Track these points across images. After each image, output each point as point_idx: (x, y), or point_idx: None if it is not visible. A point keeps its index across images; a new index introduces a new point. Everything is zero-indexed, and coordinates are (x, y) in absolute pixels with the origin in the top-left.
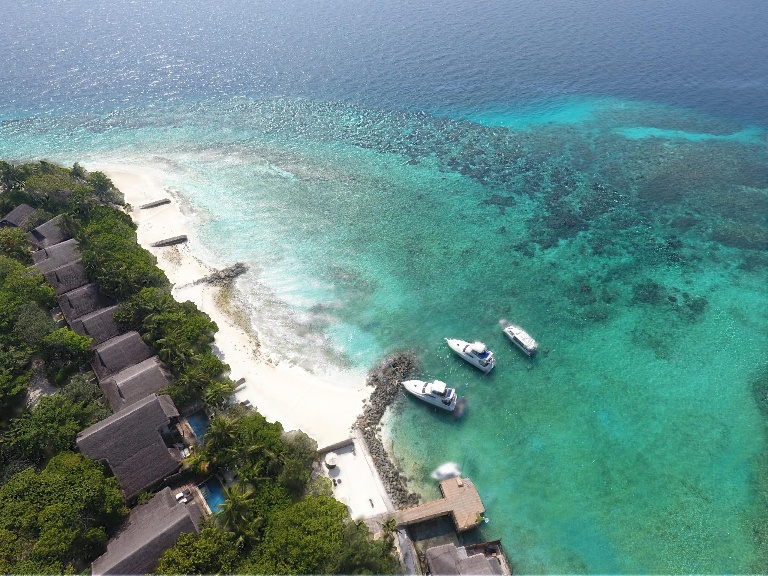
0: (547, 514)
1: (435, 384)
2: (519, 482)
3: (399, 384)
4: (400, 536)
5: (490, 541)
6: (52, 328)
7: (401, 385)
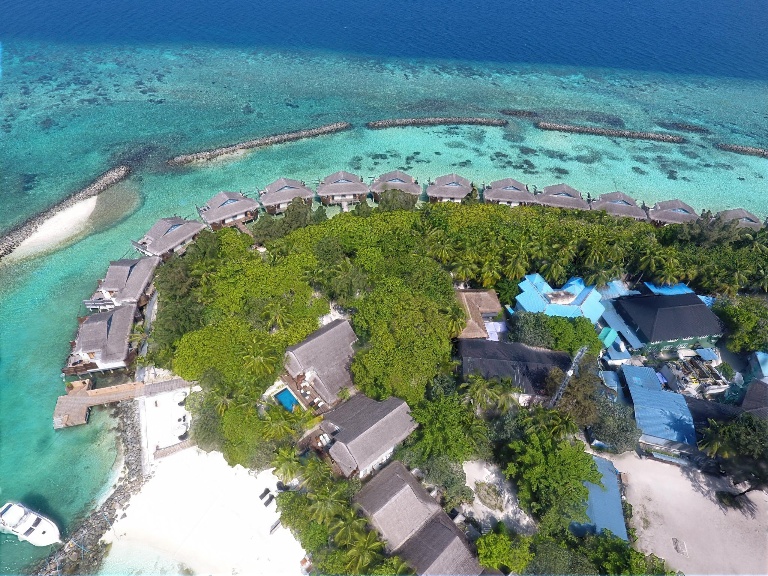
0: (4, 404)
1: (17, 516)
2: (6, 430)
3: (65, 545)
4: (142, 378)
5: (71, 368)
6: (543, 571)
7: (63, 546)
